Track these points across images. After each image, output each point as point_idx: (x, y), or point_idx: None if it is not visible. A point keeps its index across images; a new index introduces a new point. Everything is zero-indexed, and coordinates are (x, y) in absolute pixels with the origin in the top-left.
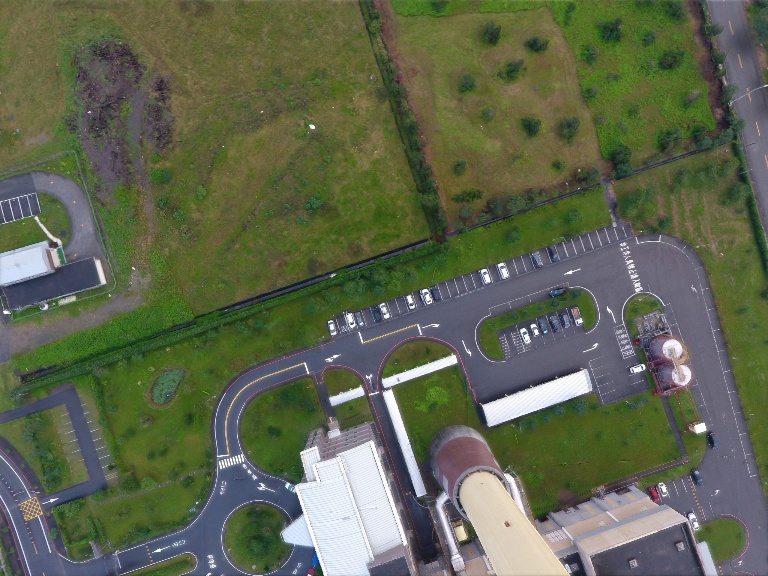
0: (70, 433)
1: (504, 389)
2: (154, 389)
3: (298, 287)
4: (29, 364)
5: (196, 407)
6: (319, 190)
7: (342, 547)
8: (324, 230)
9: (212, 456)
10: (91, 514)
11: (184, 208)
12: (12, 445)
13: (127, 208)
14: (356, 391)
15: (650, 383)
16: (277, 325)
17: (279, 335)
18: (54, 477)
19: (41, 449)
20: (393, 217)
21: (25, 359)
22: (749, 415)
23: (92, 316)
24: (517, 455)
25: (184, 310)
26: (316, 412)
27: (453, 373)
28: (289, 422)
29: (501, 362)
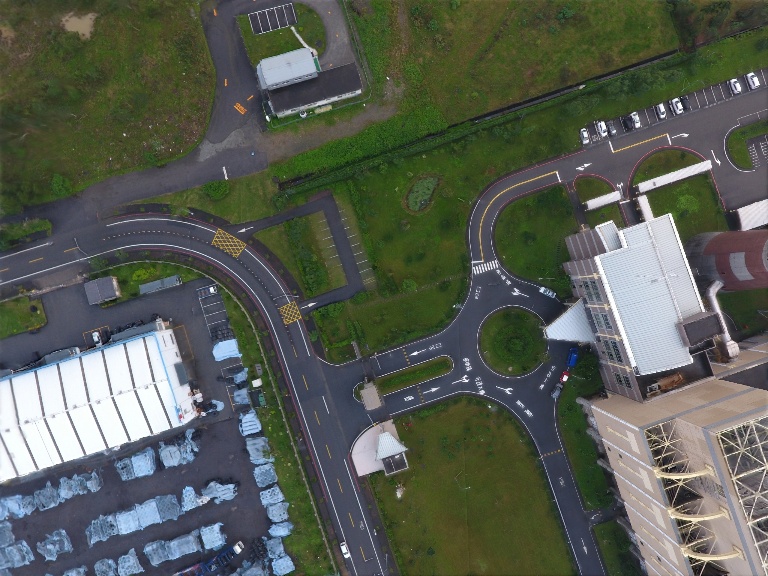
0: (328, 239)
1: (753, 198)
2: (409, 196)
3: (547, 99)
4: (287, 171)
5: (458, 208)
6: (570, 1)
7: (649, 310)
8: (576, 40)
9: (468, 261)
10: (350, 317)
11: (438, 18)
12: (271, 251)
13: (383, 17)
14: (613, 195)
15: None
16: (530, 134)
17: (532, 144)
18: (317, 278)
19: (306, 250)
20: (644, 27)
21: (284, 166)
22: None
23: (347, 125)
24: None
25: (438, 119)
26: (569, 219)
27: (703, 181)
28: (542, 229)
29: (750, 171)
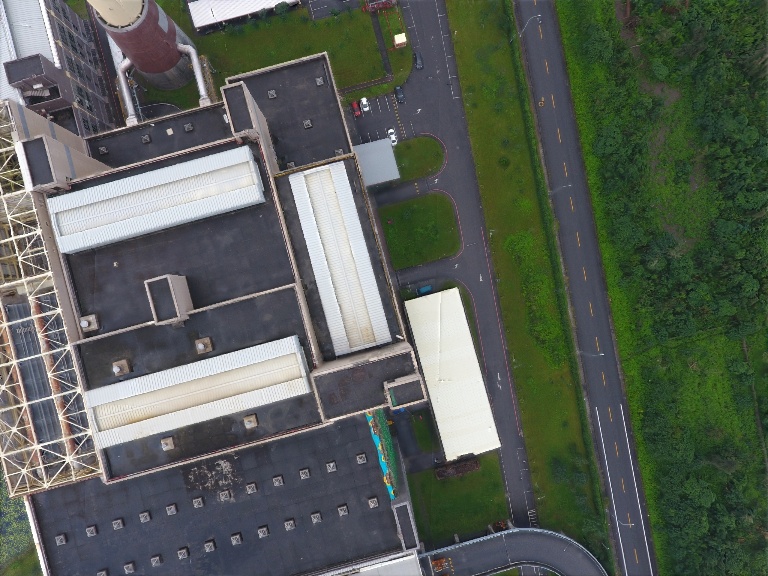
0: None
1: None
2: None
3: None
4: None
5: None
6: None
7: None
8: None
9: None
10: None
11: None
12: None
13: None
14: None
15: (361, 1)
16: None
17: None
18: None
19: None
20: None
21: None
22: (454, 35)
23: None
24: (225, 62)
25: None
26: None
27: None
28: None
29: None
